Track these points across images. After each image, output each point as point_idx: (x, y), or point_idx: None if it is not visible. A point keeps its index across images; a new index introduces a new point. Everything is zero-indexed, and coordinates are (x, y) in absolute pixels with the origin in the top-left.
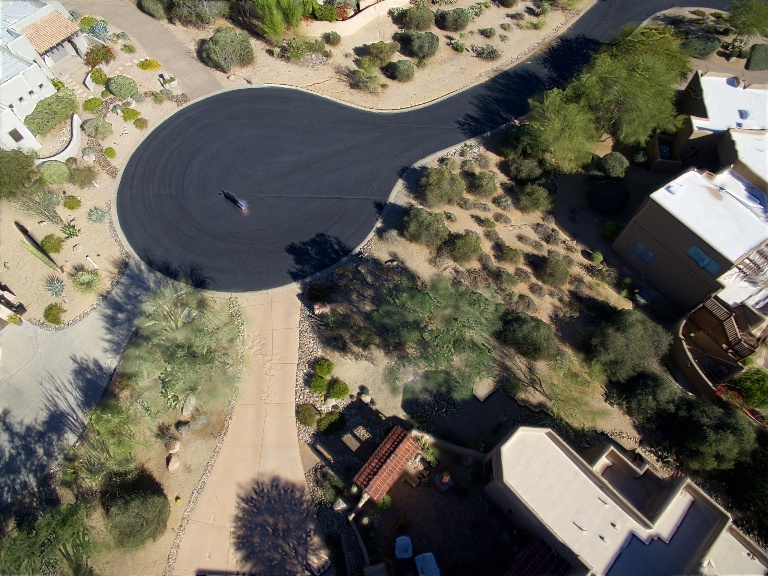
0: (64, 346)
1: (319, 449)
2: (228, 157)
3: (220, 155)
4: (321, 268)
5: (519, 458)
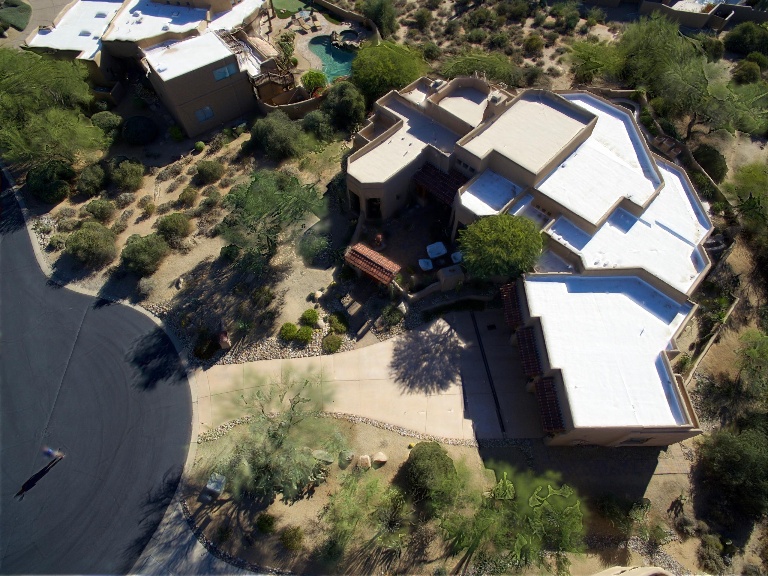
0: None
1: (361, 333)
2: None
3: None
4: (173, 352)
5: (367, 179)
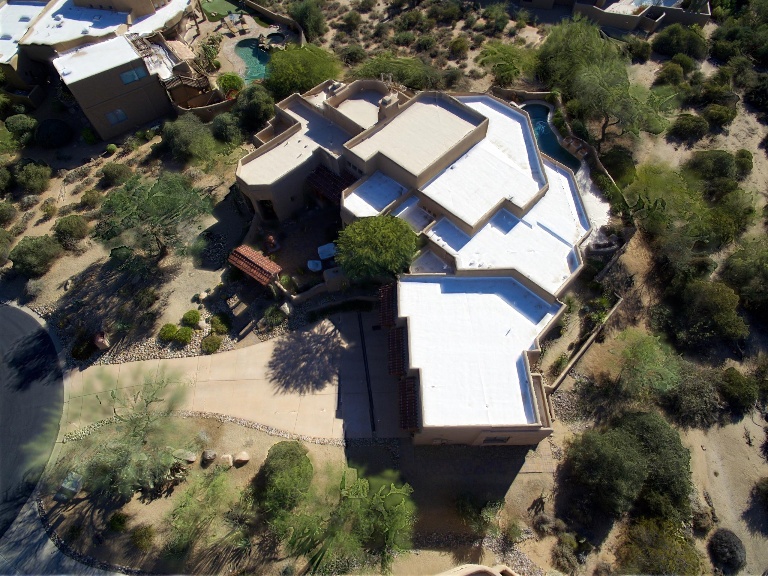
0: None
1: (243, 333)
2: None
3: None
4: (53, 352)
5: (257, 181)
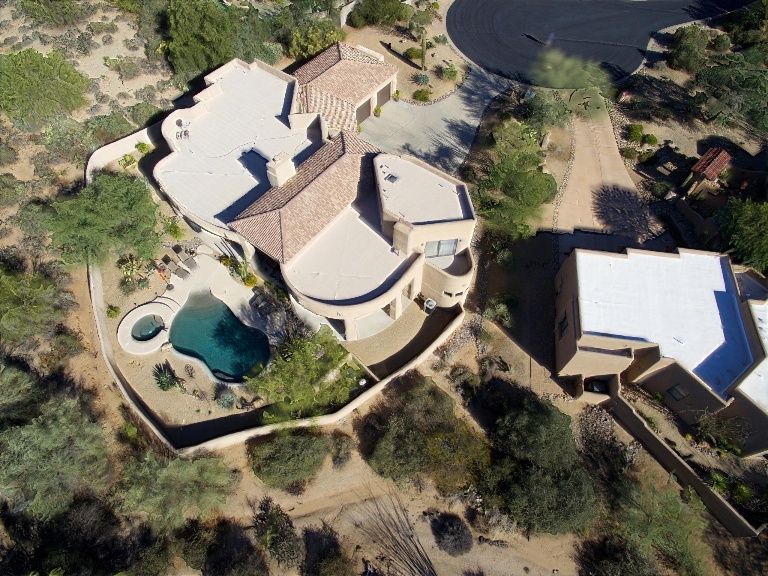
0: (435, 113)
1: (642, 173)
2: (521, 15)
3: (514, 14)
4: (612, 81)
5: None
